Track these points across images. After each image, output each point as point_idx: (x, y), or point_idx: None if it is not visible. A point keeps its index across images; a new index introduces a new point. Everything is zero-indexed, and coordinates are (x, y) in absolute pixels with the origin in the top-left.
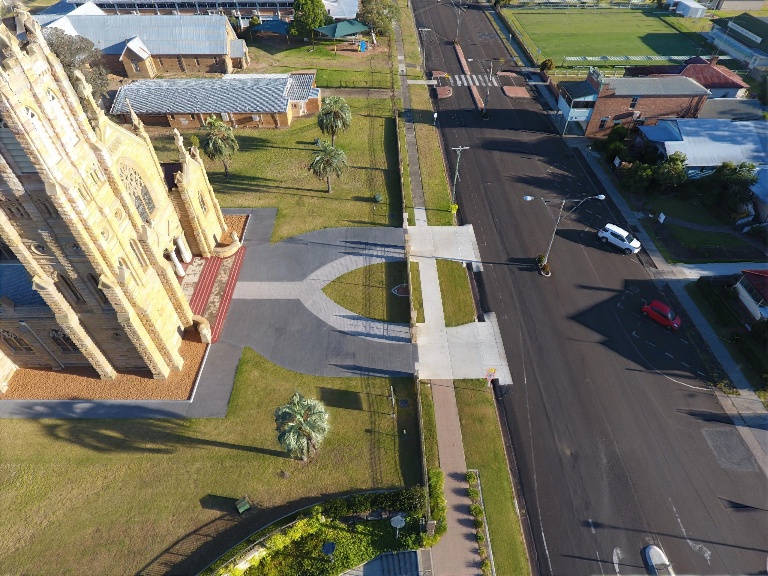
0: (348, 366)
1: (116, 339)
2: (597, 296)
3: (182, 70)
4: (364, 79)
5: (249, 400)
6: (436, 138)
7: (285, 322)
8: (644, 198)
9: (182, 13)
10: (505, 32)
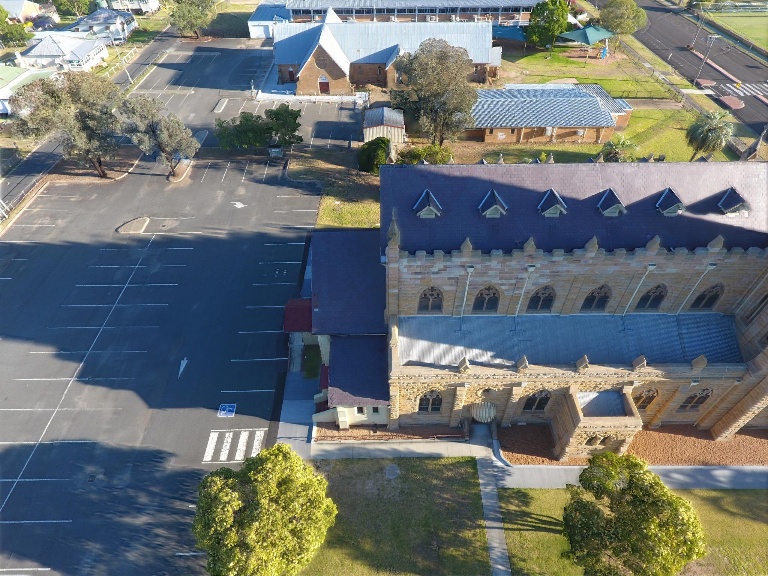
0: None
1: None
2: None
3: None
4: (637, 88)
5: None
6: None
7: None
8: None
9: (399, 19)
10: (727, 37)
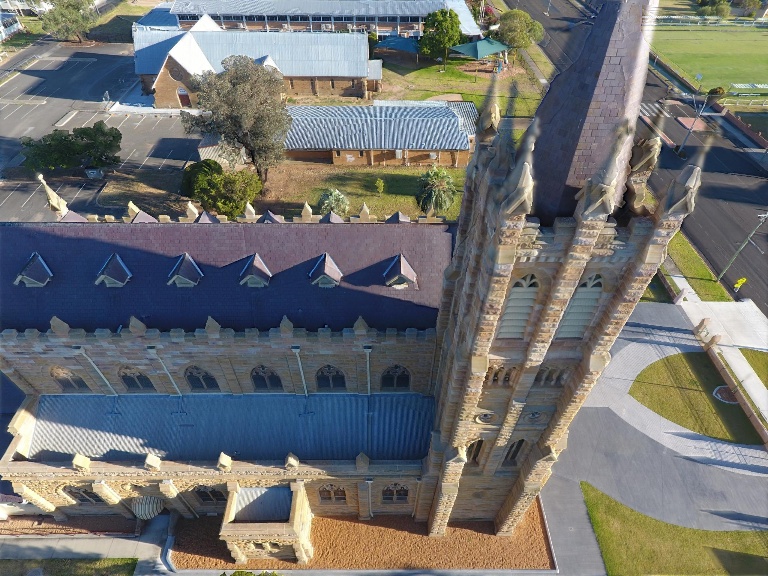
0: (726, 513)
1: (475, 495)
2: None
3: (313, 93)
4: (520, 107)
5: (631, 569)
6: None
7: (610, 443)
8: None
9: (293, 26)
10: None
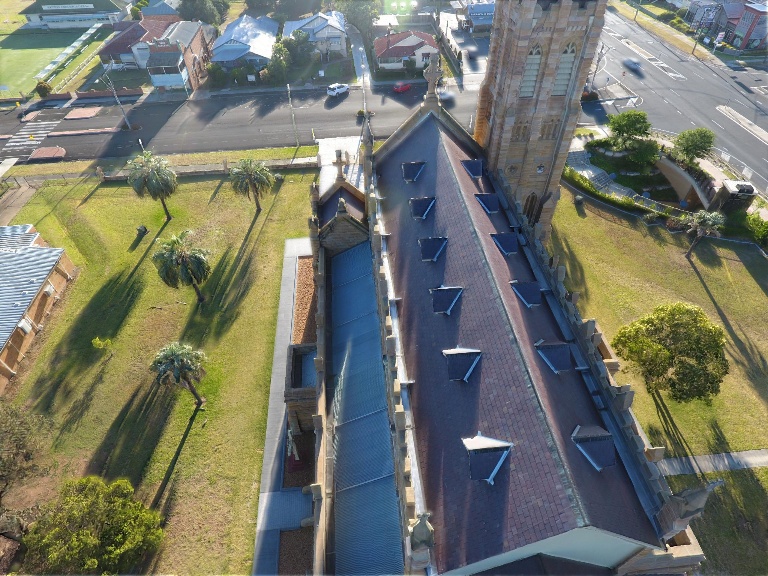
0: None
1: None
2: (389, 102)
3: None
4: None
5: None
6: (164, 156)
7: None
8: (291, 80)
9: None
10: None
